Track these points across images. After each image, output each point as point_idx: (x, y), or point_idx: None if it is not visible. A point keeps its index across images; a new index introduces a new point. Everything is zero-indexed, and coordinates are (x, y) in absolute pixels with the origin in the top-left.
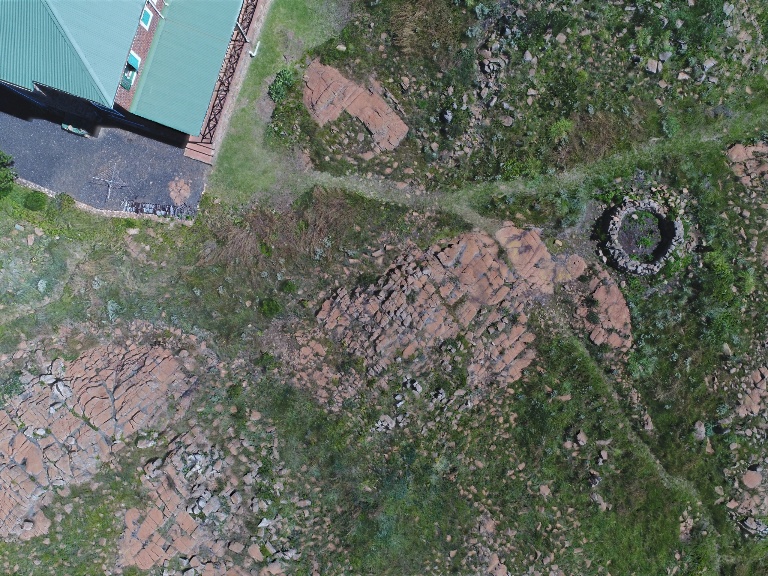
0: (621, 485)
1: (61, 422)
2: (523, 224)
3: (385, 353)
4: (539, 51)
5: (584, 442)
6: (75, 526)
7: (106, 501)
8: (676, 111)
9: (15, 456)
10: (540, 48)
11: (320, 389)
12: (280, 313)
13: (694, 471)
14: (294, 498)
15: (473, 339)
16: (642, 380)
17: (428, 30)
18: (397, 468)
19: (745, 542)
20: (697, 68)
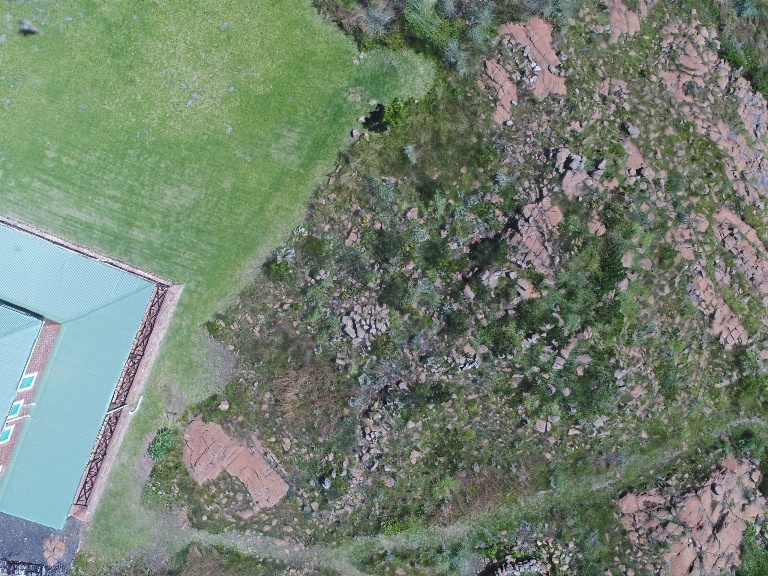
0: None
1: None
2: None
3: None
4: (423, 417)
5: None
6: None
7: None
8: (566, 463)
9: None
10: (424, 415)
11: None
12: None
13: None
14: None
15: None
16: None
17: (310, 397)
18: None
19: None
20: (587, 426)
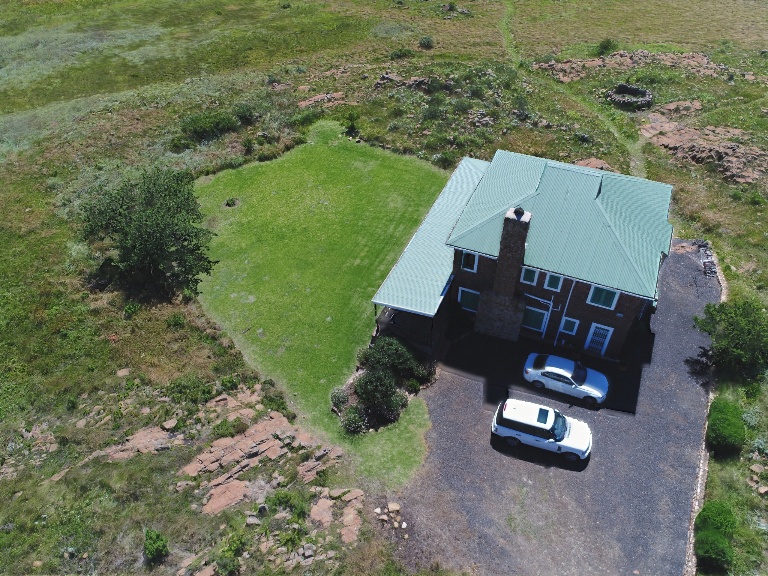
0: None
1: None
2: None
3: None
4: None
5: (767, 110)
6: None
7: None
8: None
9: None
10: None
11: None
12: None
13: None
14: None
15: None
16: (715, 99)
17: None
18: None
19: None
20: None
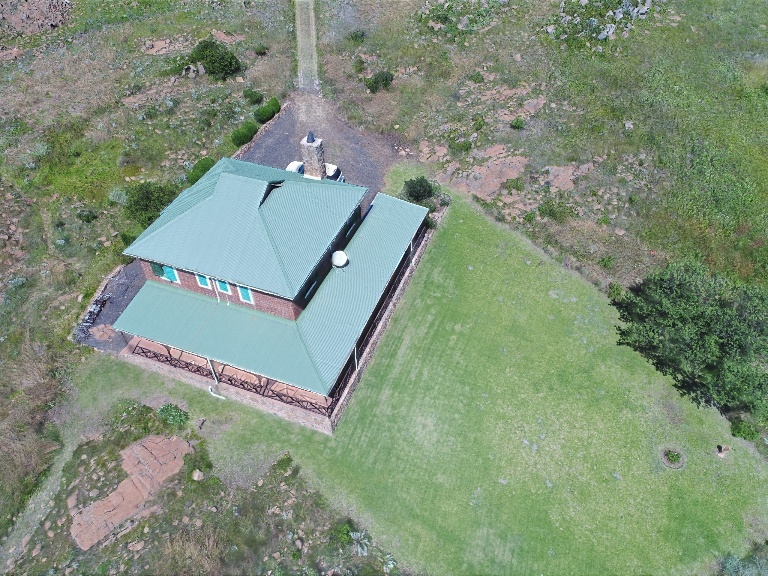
0: None
1: None
2: None
3: None
4: None
5: None
6: None
7: None
8: None
9: None
10: None
11: None
12: None
13: None
14: None
15: None
16: None
17: (183, 573)
18: None
19: None
20: None
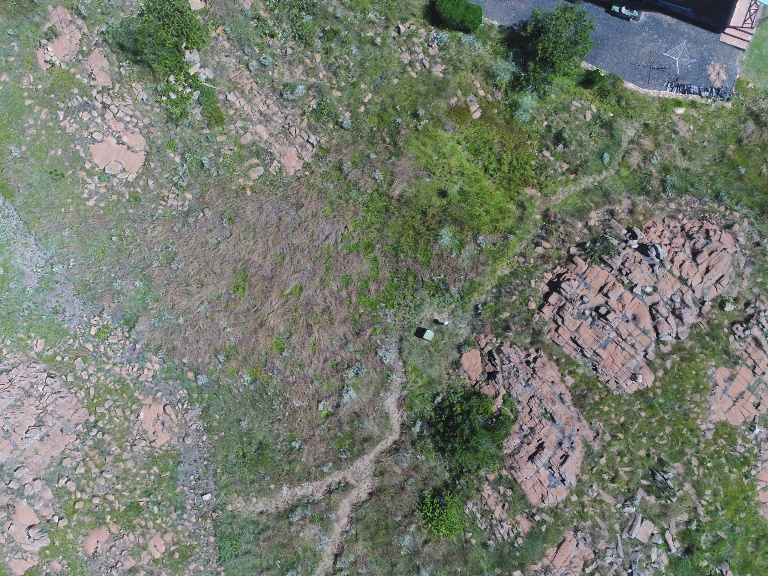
0: None
1: (664, 281)
2: None
3: None
4: None
5: None
6: (672, 382)
7: (697, 359)
8: None
9: (626, 312)
10: None
11: None
12: None
13: None
14: None
15: None
16: None
17: None
18: None
19: None
20: None
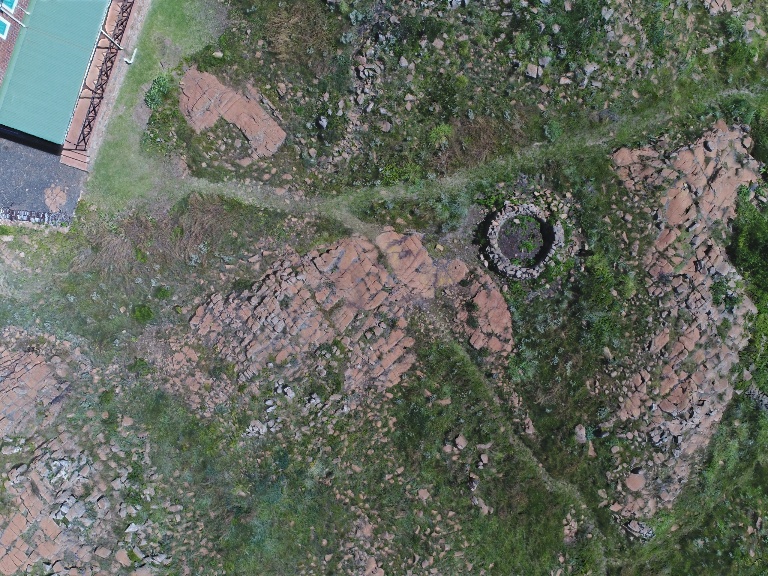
0: (503, 488)
1: None
2: (404, 229)
3: (256, 358)
4: (415, 57)
5: (462, 446)
6: None
7: None
8: (559, 115)
9: None
10: (416, 54)
11: (193, 394)
12: (154, 319)
13: (577, 474)
14: (165, 503)
15: (350, 344)
16: (523, 384)
17: (303, 36)
18: (270, 473)
19: (631, 545)
20: (578, 73)
